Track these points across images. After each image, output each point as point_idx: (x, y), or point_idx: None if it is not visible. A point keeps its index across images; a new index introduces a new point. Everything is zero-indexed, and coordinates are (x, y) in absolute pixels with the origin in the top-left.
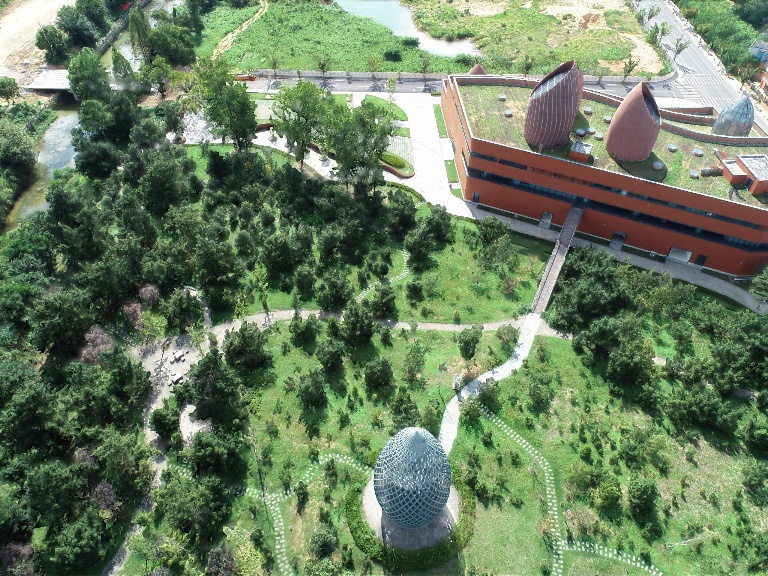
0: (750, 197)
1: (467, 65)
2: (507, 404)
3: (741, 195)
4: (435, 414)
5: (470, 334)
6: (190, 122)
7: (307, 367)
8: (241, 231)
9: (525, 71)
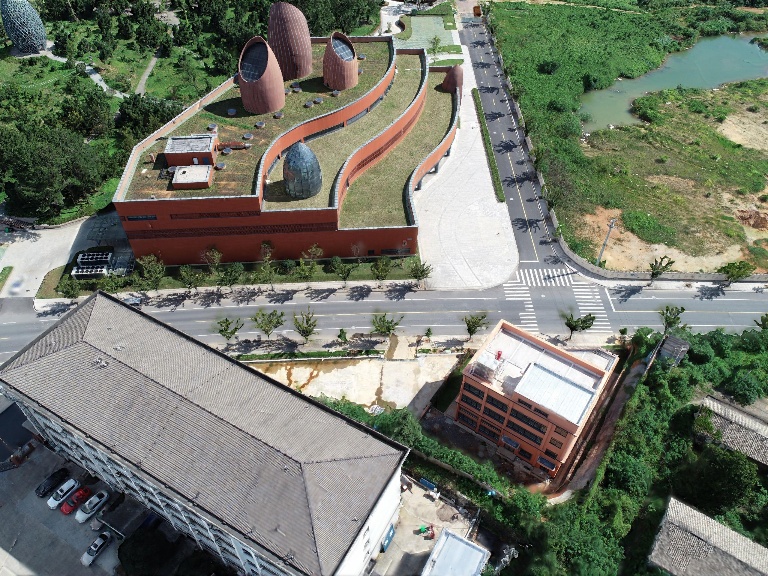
0: None
1: (549, 109)
2: None
3: None
4: (66, 45)
5: None
6: (411, 6)
7: None
8: (238, 5)
9: (525, 131)
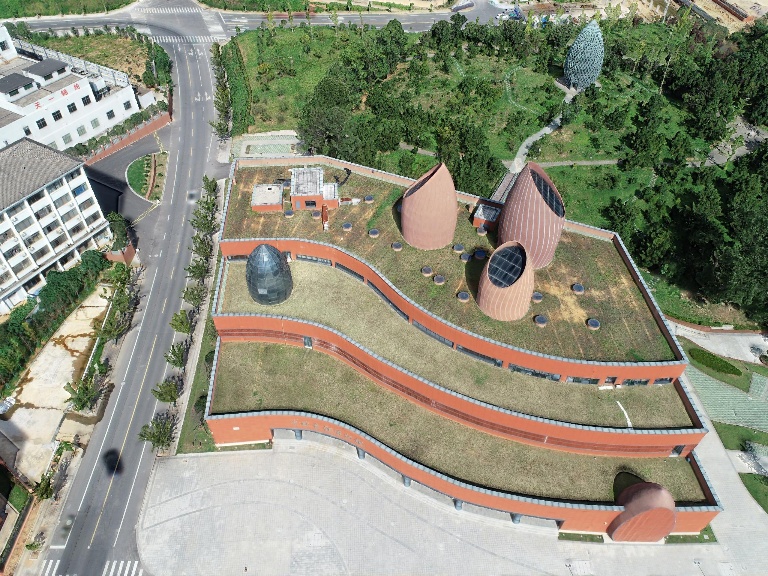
0: (327, 179)
1: None
2: (534, 120)
3: (334, 181)
4: None
5: (570, 105)
6: None
7: (664, 131)
8: None
9: None
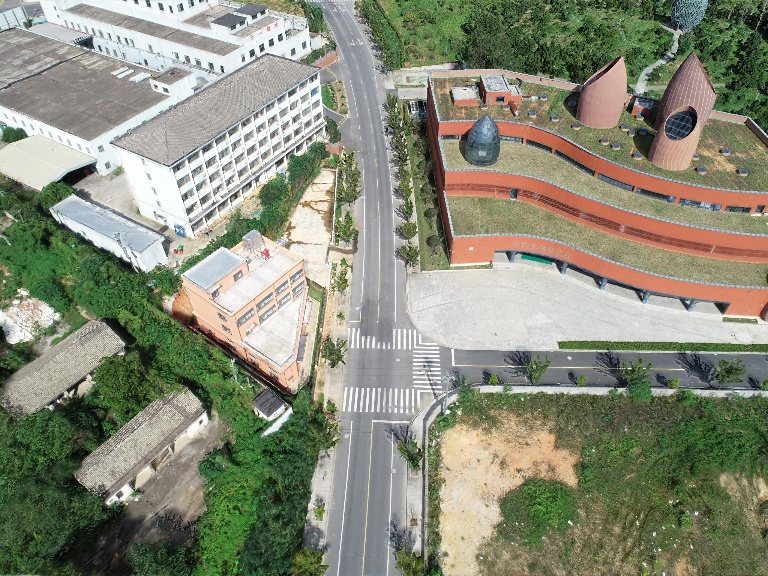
0: None
1: None
2: (649, 54)
3: None
4: None
5: None
6: None
7: None
8: None
9: None
